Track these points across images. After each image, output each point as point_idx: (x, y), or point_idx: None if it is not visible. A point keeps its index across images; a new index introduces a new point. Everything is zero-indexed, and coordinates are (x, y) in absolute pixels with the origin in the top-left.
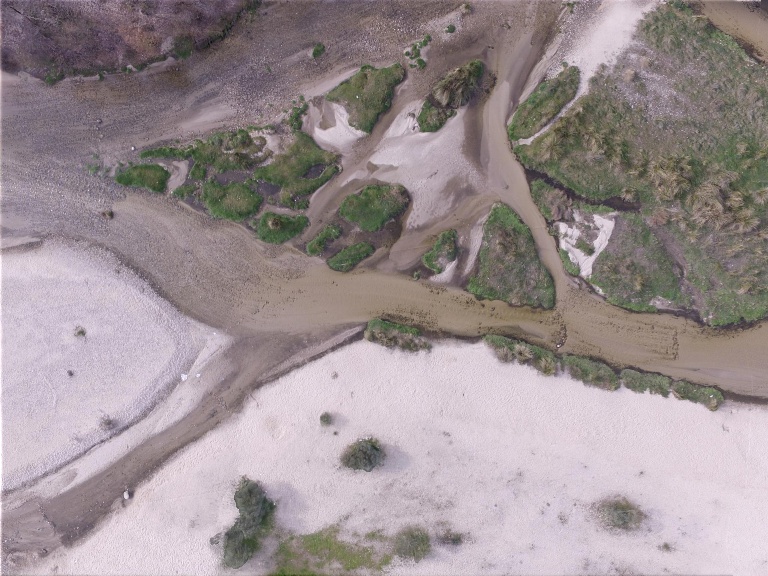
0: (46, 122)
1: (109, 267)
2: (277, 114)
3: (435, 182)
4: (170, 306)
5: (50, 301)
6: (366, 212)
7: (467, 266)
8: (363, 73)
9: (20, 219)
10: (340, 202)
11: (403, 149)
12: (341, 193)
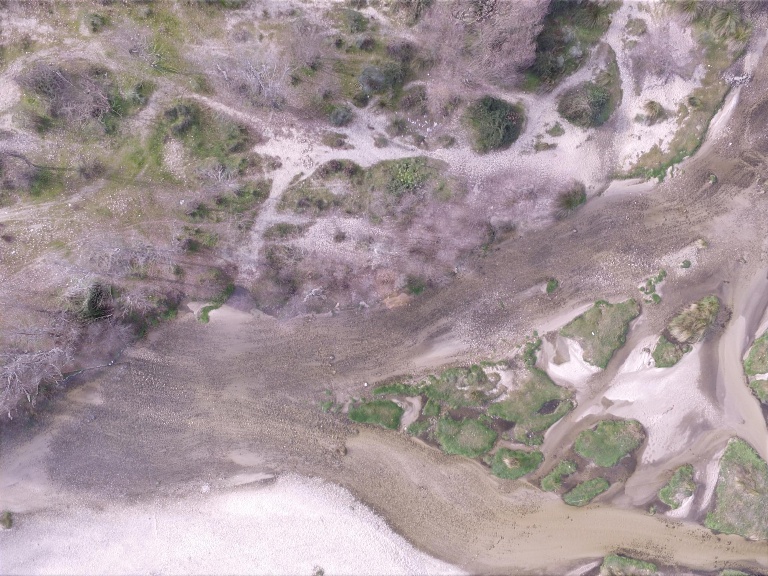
0: (278, 358)
1: (344, 504)
2: (510, 349)
3: (671, 417)
4: (405, 542)
5: (287, 540)
6: (602, 448)
7: (704, 501)
8: (598, 309)
9: (253, 456)
10: (575, 437)
11: (638, 384)
12: (575, 428)
